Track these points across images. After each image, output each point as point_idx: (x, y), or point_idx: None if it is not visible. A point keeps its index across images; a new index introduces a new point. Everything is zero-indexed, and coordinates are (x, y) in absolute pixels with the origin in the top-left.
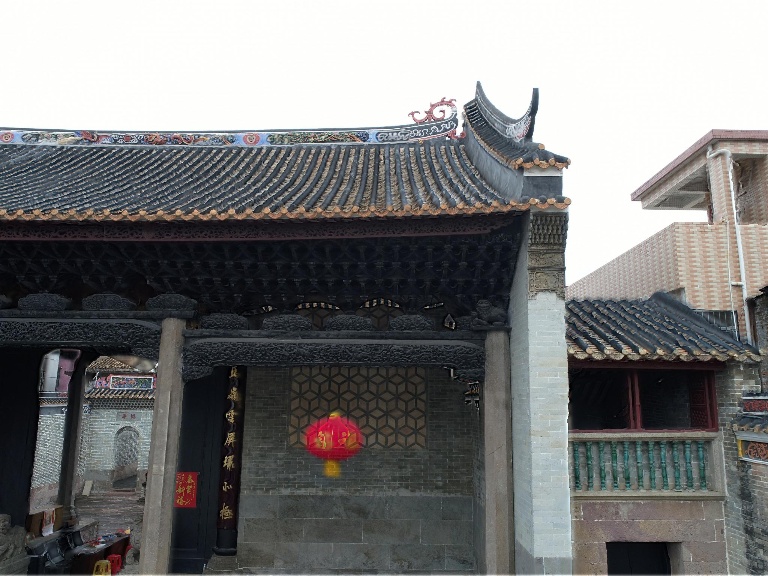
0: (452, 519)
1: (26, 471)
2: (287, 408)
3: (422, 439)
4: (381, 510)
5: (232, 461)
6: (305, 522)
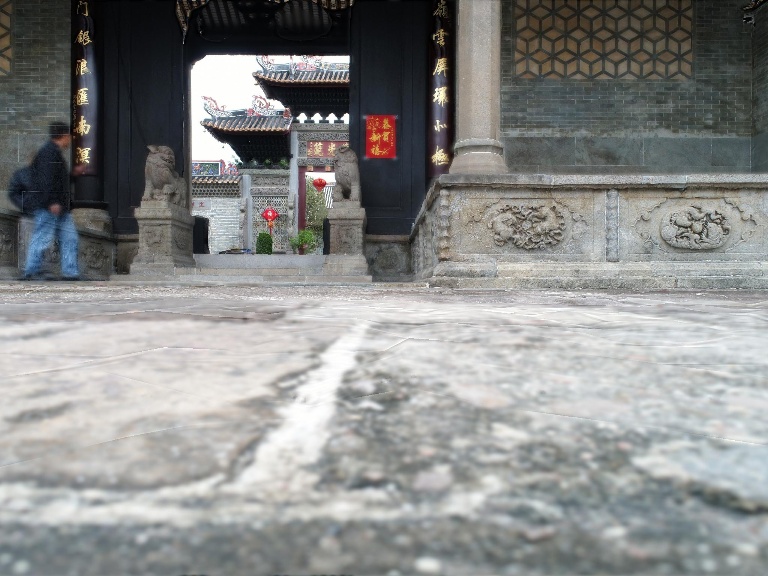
0: (725, 165)
1: (176, 115)
2: (511, 29)
3: (687, 67)
4: (635, 154)
5: (445, 94)
6: (539, 169)
